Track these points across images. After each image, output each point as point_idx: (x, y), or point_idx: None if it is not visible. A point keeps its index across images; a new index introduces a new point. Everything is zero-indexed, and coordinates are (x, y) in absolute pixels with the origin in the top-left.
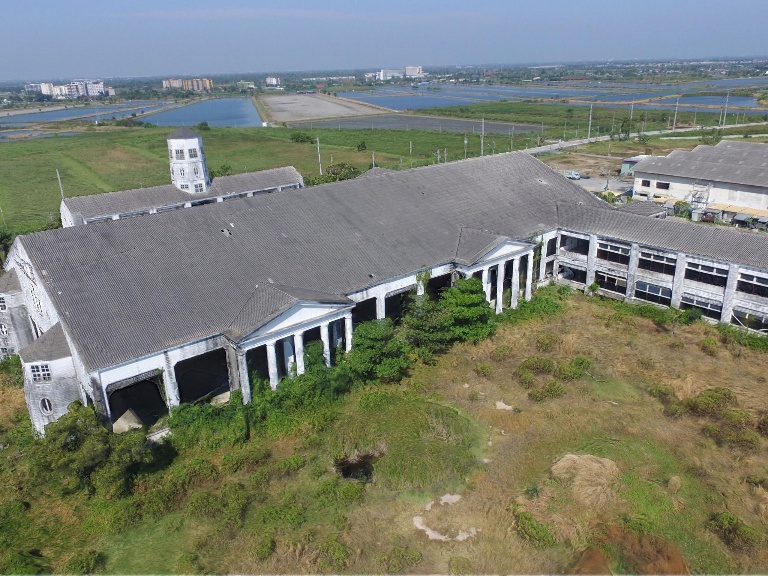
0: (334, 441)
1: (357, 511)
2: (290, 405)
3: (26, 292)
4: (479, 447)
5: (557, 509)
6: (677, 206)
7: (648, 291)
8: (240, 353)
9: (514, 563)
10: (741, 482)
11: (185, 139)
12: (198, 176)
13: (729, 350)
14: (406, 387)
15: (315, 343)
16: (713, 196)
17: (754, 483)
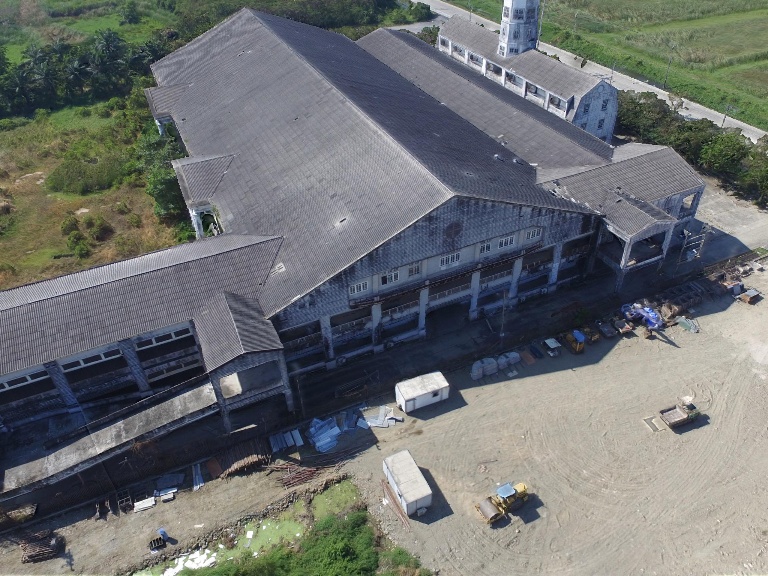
0: None
1: None
2: None
3: None
4: None
5: None
6: None
7: None
8: None
9: None
10: None
11: None
12: None
13: None
14: None
15: None
16: None
17: None
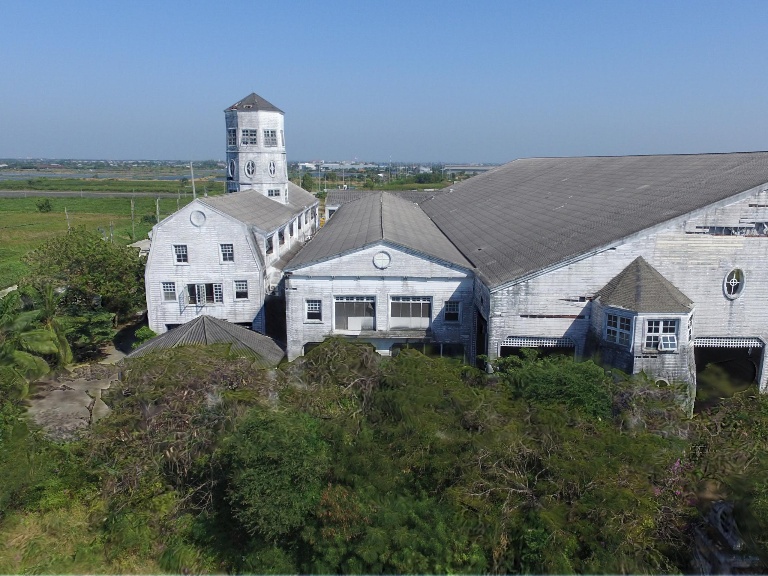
0: None
1: None
2: None
3: (746, 284)
4: None
5: None
6: None
7: None
8: None
9: None
10: None
11: (279, 113)
12: (285, 176)
13: None
14: None
15: None
16: None
17: None
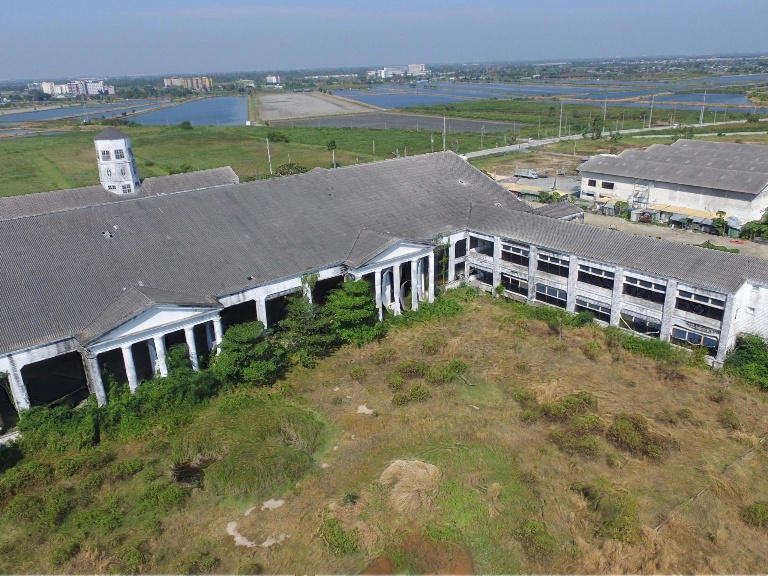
0: (178, 445)
1: (175, 516)
2: (149, 408)
3: None
4: (323, 452)
5: (369, 516)
6: (617, 206)
7: (547, 293)
8: (89, 356)
9: (307, 570)
10: (566, 489)
11: (110, 140)
12: (126, 177)
13: (612, 354)
14: (275, 390)
15: (179, 346)
16: (654, 196)
17: (577, 490)
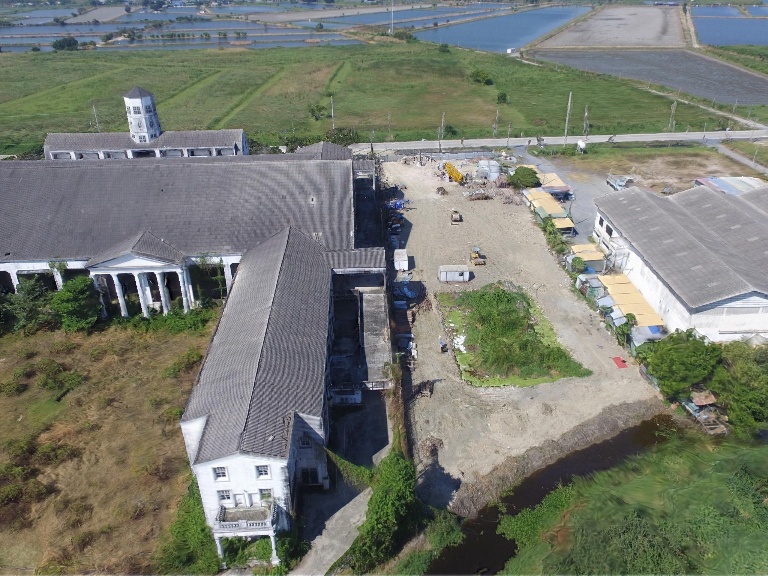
0: None
1: None
2: None
3: None
4: None
5: None
6: (572, 262)
7: None
8: None
9: None
10: None
11: (130, 98)
12: (142, 129)
13: None
14: None
15: None
16: (632, 263)
17: None
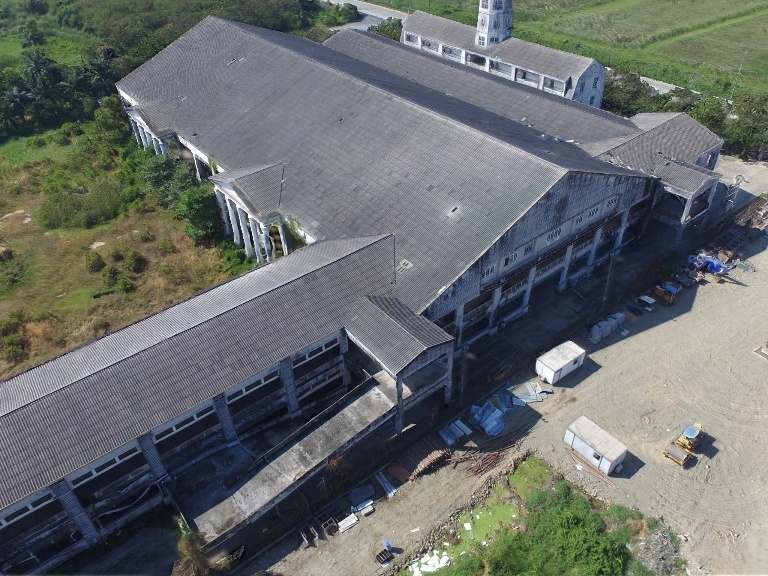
0: None
1: None
2: None
3: None
4: (61, 231)
5: None
6: None
7: None
8: None
9: None
10: None
11: None
12: (484, 28)
13: None
14: None
15: None
16: None
17: None
